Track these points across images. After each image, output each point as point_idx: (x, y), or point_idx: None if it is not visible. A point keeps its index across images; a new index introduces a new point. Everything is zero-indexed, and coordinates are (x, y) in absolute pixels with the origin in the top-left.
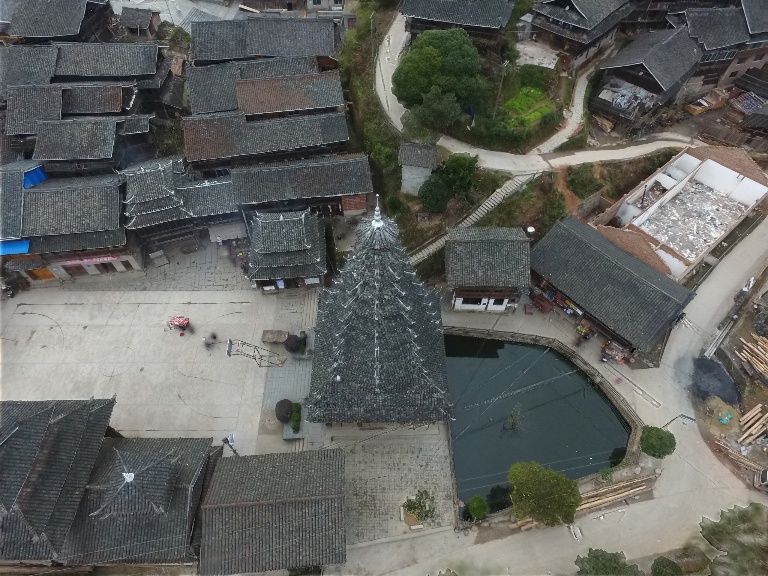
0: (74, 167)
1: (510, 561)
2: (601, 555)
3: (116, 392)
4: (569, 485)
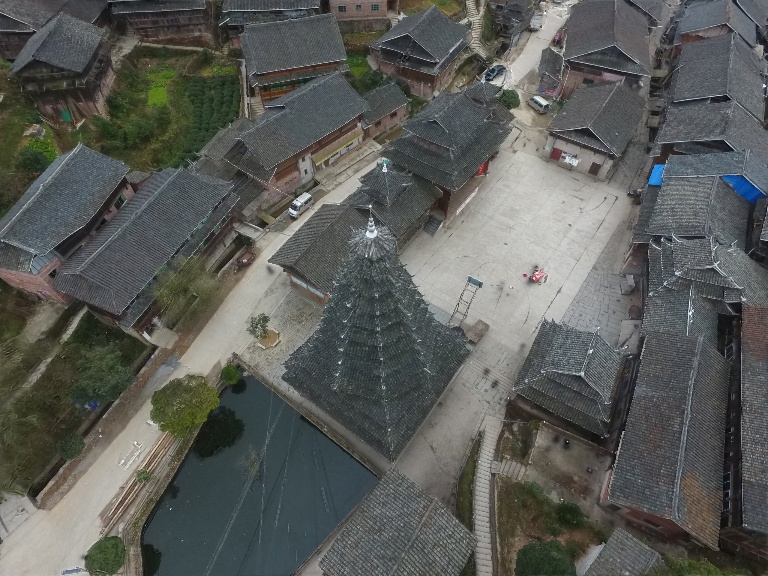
0: (759, 218)
1: (191, 372)
2: (118, 381)
3: (495, 227)
4: (164, 411)
